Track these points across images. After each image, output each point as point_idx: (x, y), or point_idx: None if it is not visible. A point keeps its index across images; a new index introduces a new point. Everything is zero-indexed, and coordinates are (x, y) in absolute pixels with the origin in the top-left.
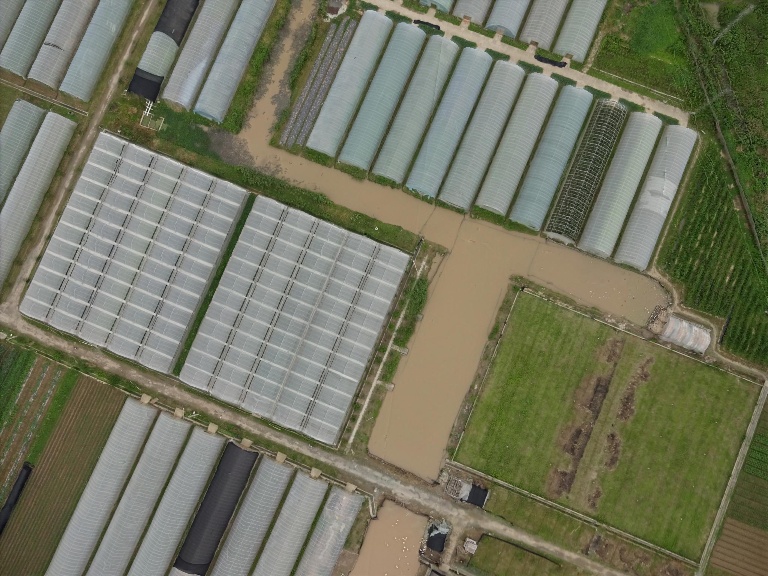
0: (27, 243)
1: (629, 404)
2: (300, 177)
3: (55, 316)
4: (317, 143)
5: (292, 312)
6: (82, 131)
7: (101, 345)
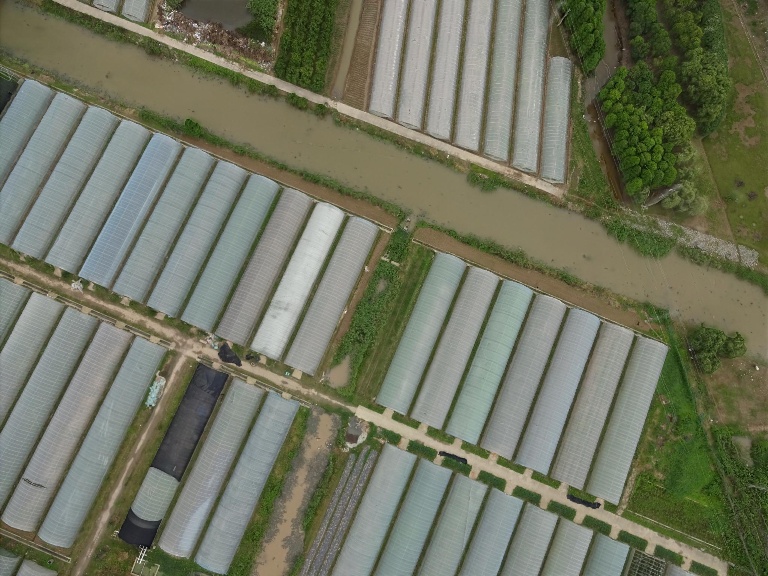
0: None
1: None
2: None
3: None
4: None
5: None
6: None
7: None
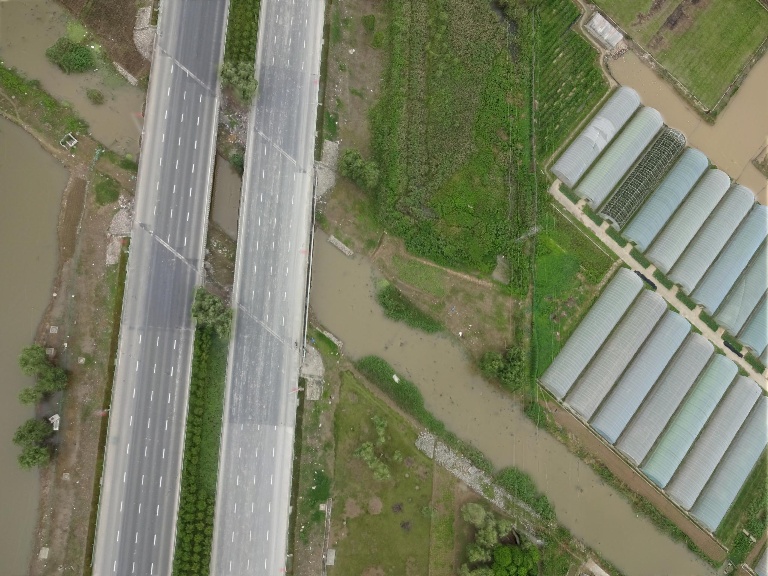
0: None
1: (656, 4)
2: None
3: None
4: None
5: None
6: None
7: None
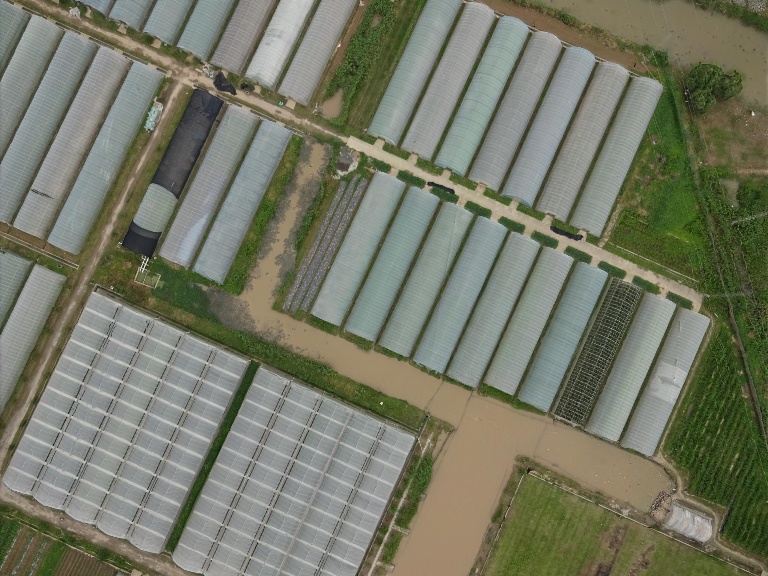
0: (11, 404)
1: None
2: (303, 345)
3: (41, 490)
4: (323, 314)
5: (292, 495)
6: (72, 285)
7: (90, 522)
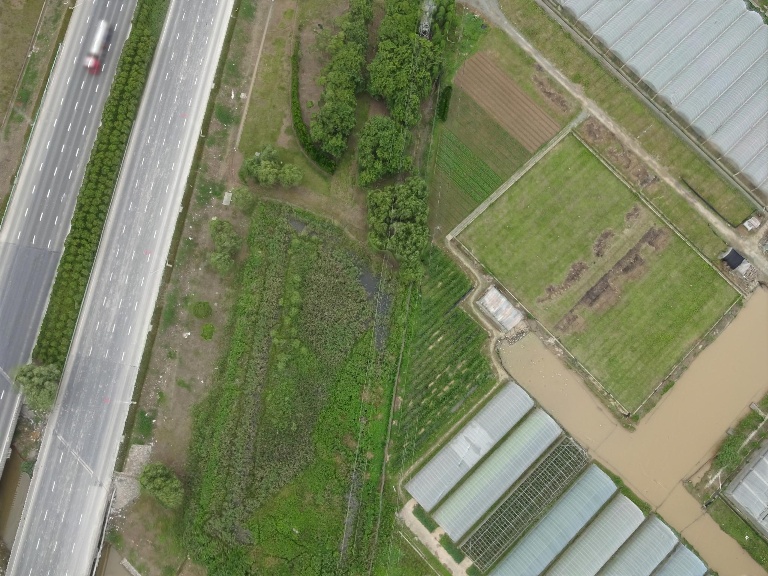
0: None
1: (574, 274)
2: None
3: None
4: None
5: None
6: None
7: None
